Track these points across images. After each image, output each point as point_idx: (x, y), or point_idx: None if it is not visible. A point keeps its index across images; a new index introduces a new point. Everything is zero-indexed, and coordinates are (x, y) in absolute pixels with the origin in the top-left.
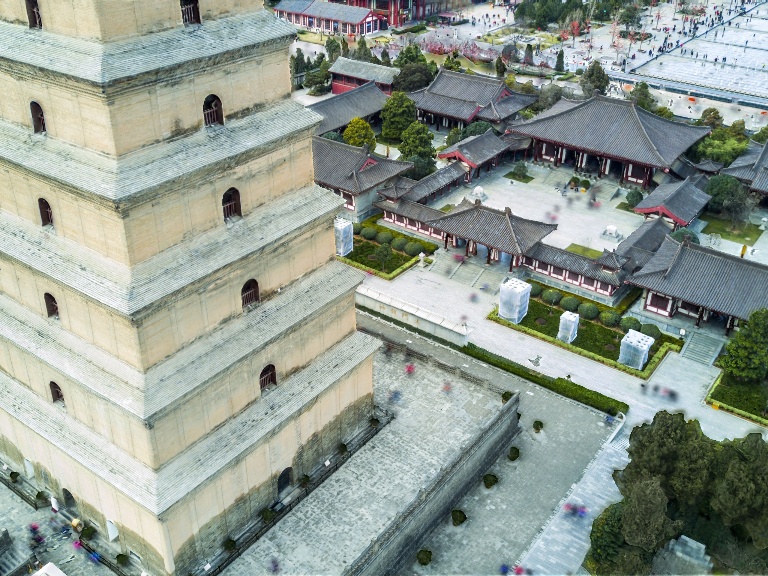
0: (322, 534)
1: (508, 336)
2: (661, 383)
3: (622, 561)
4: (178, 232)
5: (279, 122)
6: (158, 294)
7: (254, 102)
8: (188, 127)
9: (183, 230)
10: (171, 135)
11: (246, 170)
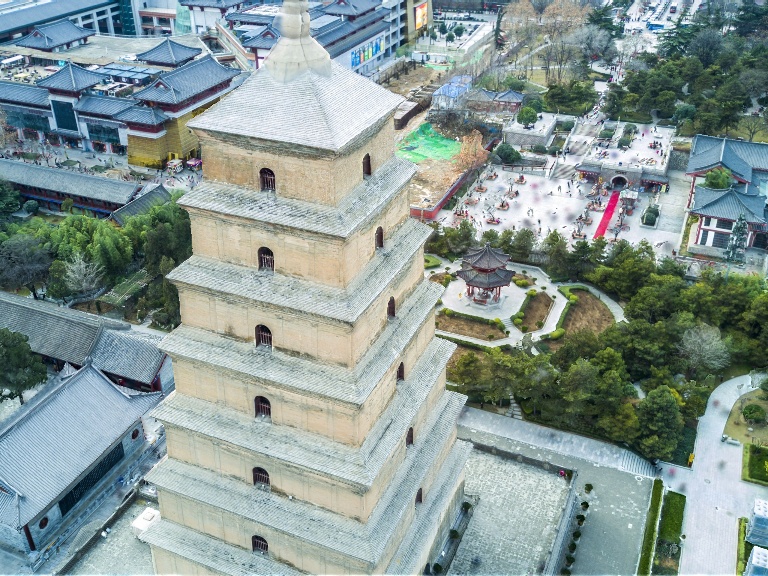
0: None
1: None
2: None
3: None
4: (214, 395)
5: (317, 379)
6: (171, 419)
7: (306, 351)
8: (240, 336)
9: (218, 397)
10: (226, 333)
11: (279, 393)
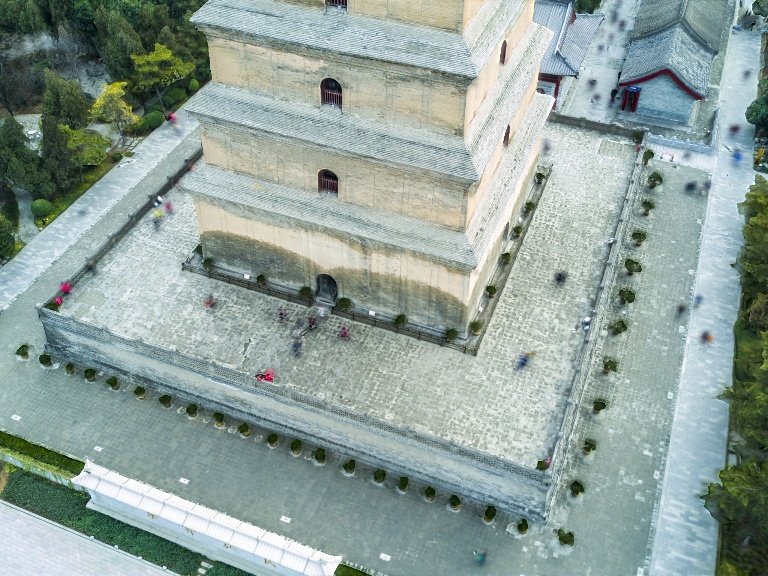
0: None
1: (16, 575)
2: None
3: (2, 151)
4: None
5: None
6: None
7: None
8: None
9: None
10: None
11: None
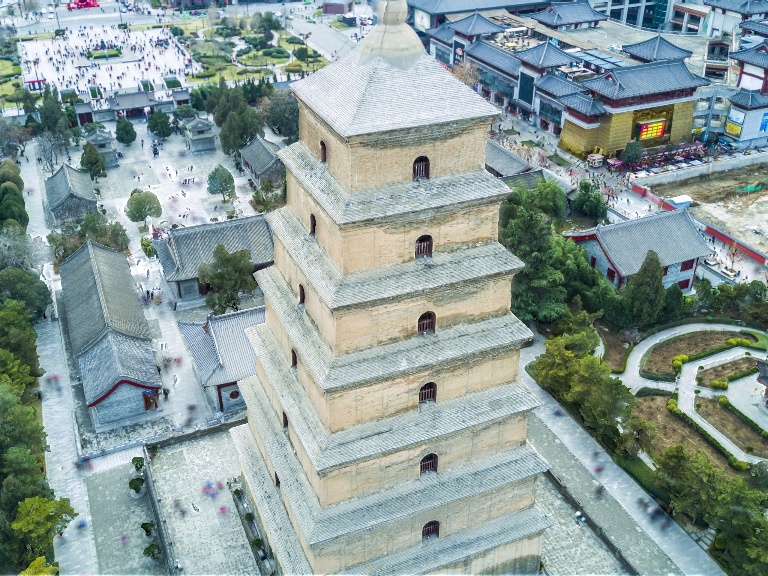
0: (224, 574)
1: None
2: None
3: None
4: None
5: None
6: None
7: None
8: None
9: None
10: None
11: None
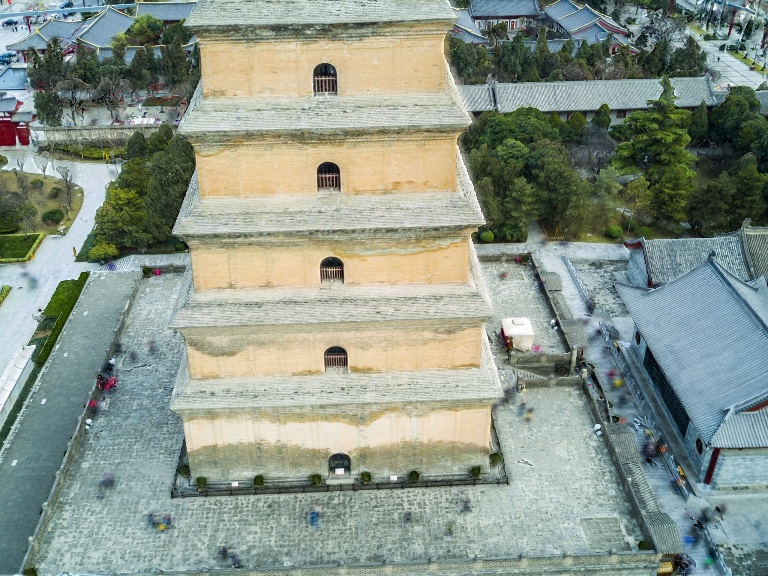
0: None
1: None
2: (12, 282)
3: None
4: None
5: None
6: None
7: None
8: None
9: None
10: None
11: None
